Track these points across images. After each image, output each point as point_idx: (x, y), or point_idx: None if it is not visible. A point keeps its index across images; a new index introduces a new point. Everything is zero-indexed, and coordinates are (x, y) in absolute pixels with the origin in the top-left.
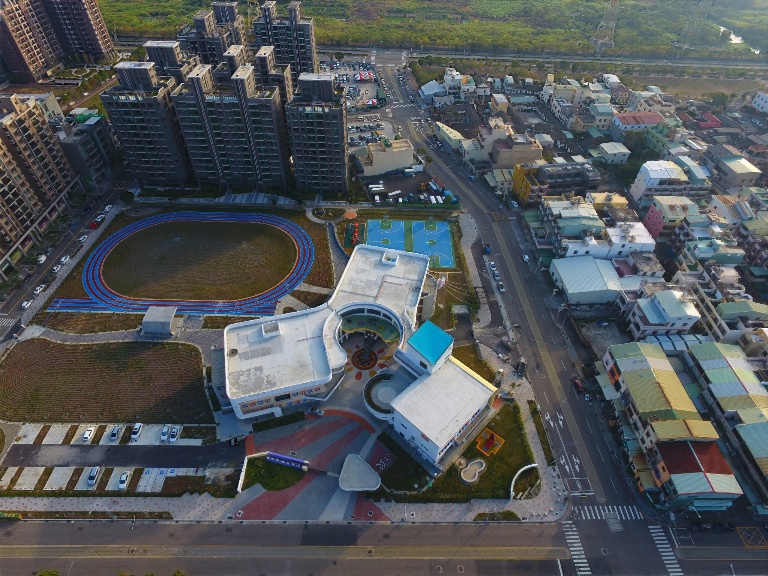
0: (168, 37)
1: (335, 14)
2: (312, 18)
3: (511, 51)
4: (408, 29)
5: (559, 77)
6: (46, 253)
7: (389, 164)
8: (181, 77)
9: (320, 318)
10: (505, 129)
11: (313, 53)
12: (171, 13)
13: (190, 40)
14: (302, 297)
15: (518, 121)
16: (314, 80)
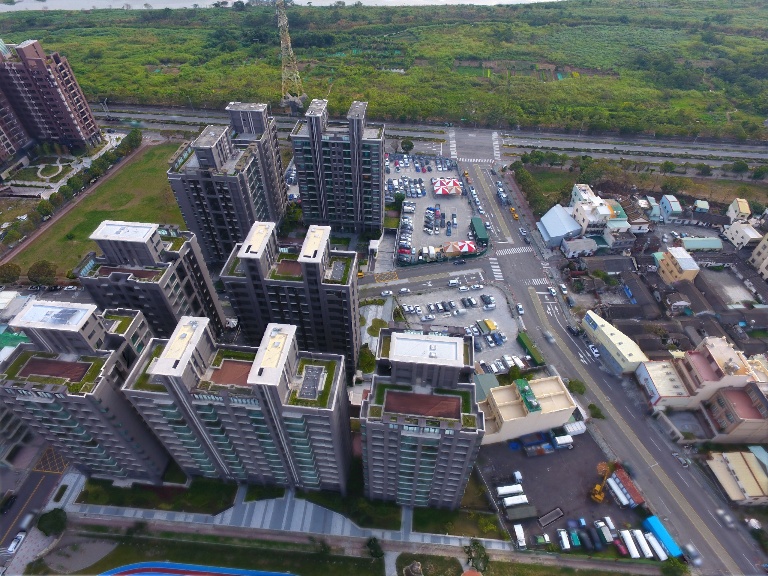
0: (176, 106)
1: (391, 63)
2: (383, 126)
3: (646, 135)
4: (488, 88)
5: (754, 203)
6: None
7: (527, 427)
8: (159, 292)
9: None
10: (748, 375)
11: (382, 176)
12: (186, 60)
13: (188, 178)
14: None
15: (719, 304)
16: (423, 363)
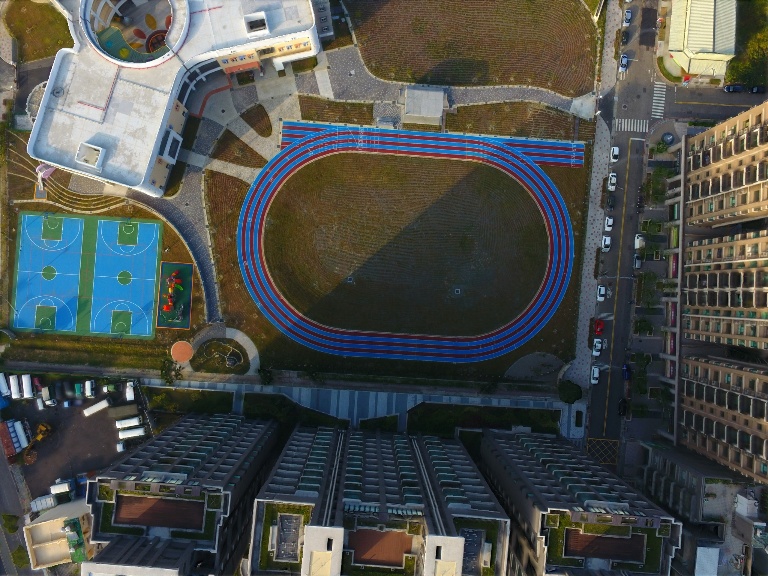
0: None
1: None
2: None
3: None
4: None
5: None
6: (640, 257)
7: None
8: None
9: (195, 44)
10: None
11: None
12: None
13: None
14: (248, 154)
15: None
16: (134, 567)
